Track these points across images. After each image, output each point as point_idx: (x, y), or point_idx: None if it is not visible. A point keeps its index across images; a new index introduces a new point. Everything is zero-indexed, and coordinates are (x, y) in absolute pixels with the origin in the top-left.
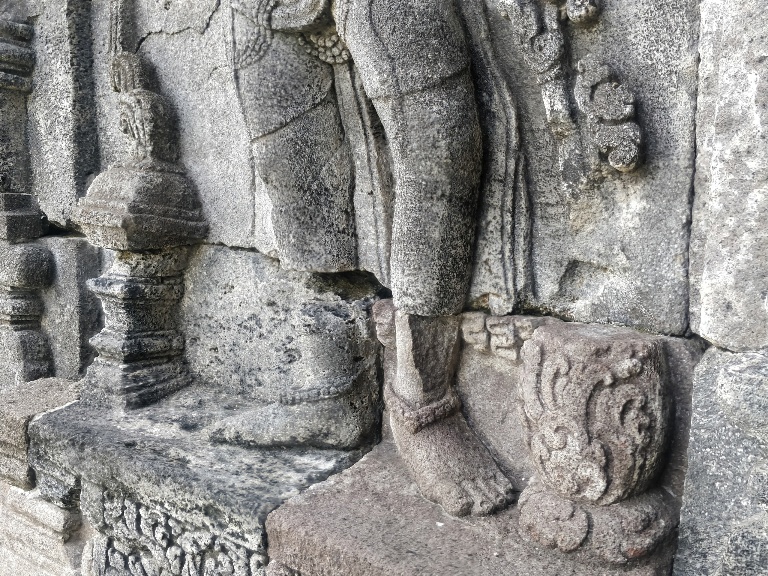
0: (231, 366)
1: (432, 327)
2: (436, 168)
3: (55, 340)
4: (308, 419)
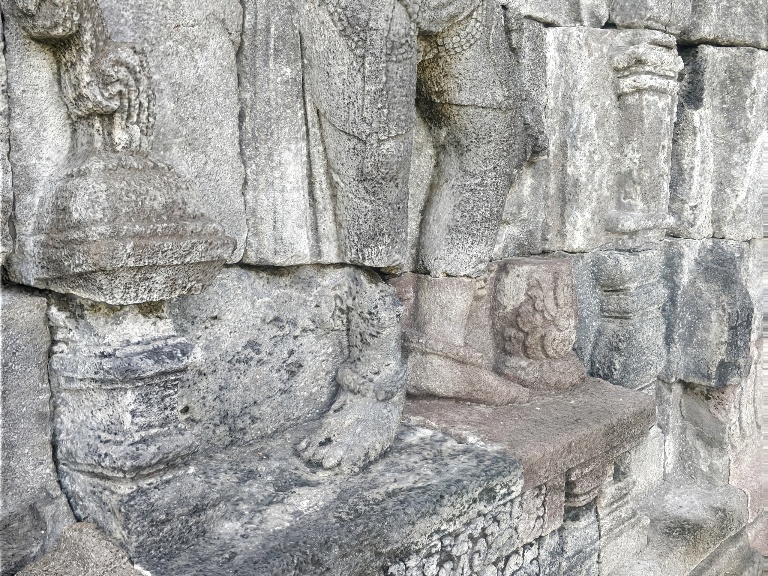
0: (214, 418)
1: None
2: None
3: None
4: None
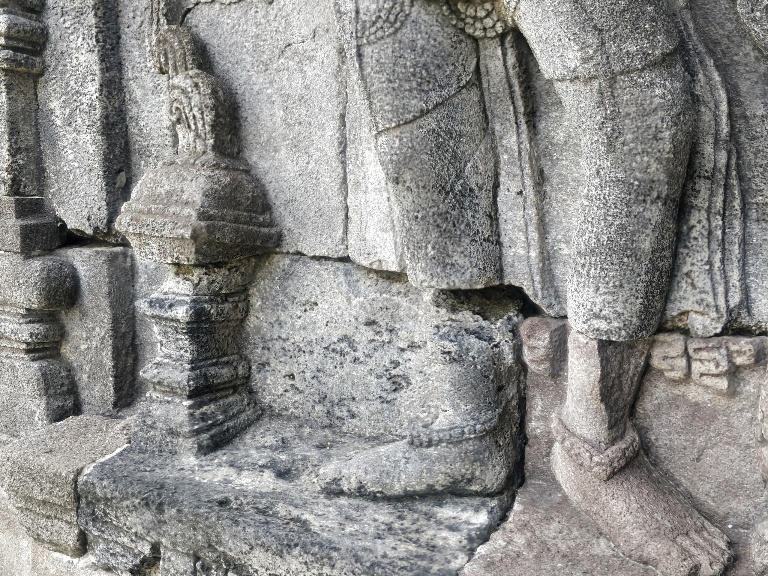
0: (314, 395)
1: (619, 353)
2: (654, 165)
3: (80, 369)
4: (449, 463)
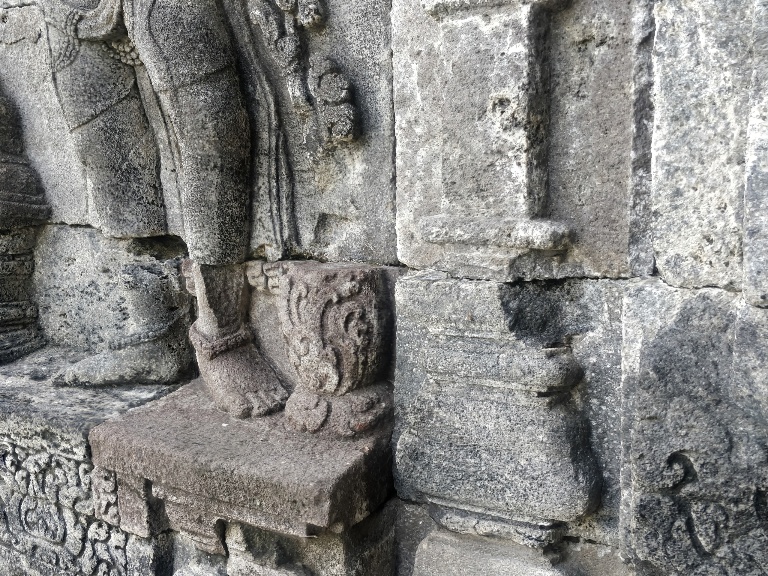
0: (78, 328)
1: (222, 275)
2: (207, 145)
3: None
4: (133, 360)
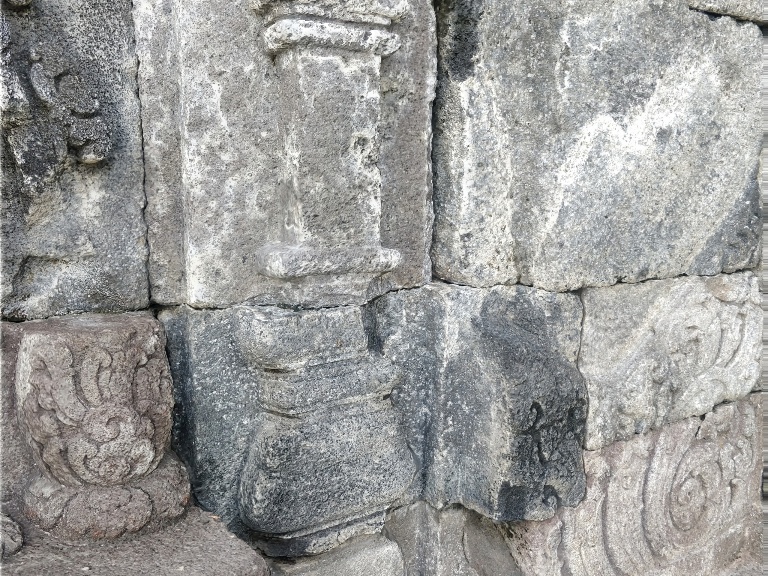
0: None
1: None
2: None
3: None
4: None
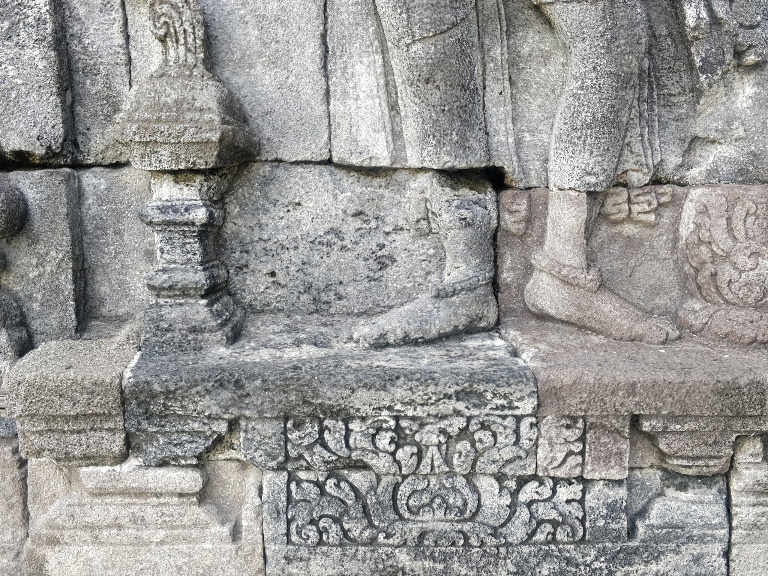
0: (298, 287)
1: (590, 203)
2: (635, 62)
3: (29, 299)
4: (468, 307)
